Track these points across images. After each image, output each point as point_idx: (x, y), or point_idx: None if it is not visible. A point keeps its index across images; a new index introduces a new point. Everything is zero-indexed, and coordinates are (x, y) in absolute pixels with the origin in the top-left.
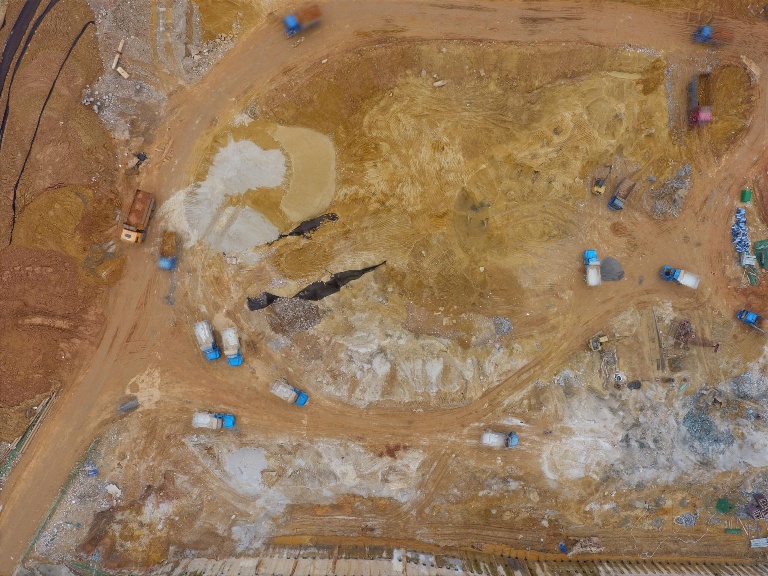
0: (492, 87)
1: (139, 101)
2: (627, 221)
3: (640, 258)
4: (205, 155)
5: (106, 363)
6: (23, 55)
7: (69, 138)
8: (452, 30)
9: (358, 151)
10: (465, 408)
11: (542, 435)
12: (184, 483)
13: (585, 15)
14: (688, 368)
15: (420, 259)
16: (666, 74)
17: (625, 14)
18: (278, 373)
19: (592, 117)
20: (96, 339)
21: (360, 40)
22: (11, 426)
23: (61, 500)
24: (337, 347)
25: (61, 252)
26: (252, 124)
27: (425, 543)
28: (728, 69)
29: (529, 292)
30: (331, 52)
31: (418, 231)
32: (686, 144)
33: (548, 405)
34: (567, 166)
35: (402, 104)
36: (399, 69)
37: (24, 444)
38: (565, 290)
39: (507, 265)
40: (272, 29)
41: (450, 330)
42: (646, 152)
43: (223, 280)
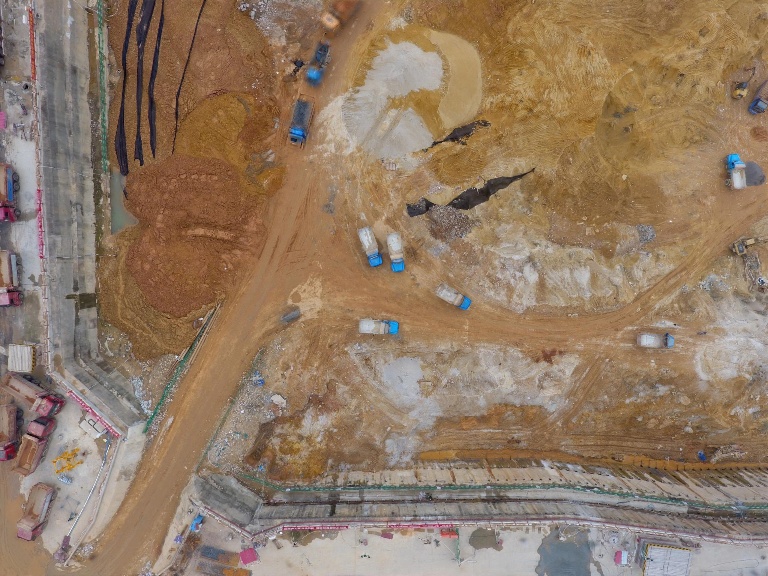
0: None
1: (295, 6)
2: (767, 125)
3: None
4: (362, 60)
5: (268, 273)
6: None
7: (228, 44)
8: None
9: (503, 58)
10: (619, 312)
11: (695, 336)
12: (345, 393)
13: None
14: None
15: (566, 167)
16: None
17: None
18: (439, 279)
19: (733, 20)
20: (257, 250)
21: None
22: (180, 336)
23: (230, 410)
24: (490, 255)
25: (223, 160)
26: (407, 28)
27: (568, 455)
28: None
29: (671, 199)
30: None
31: (567, 137)
32: None
33: (698, 308)
34: (712, 68)
35: (545, 10)
36: None
37: (192, 355)
38: (707, 196)
39: (649, 173)
40: None
41: (593, 240)
42: None
43: (382, 187)
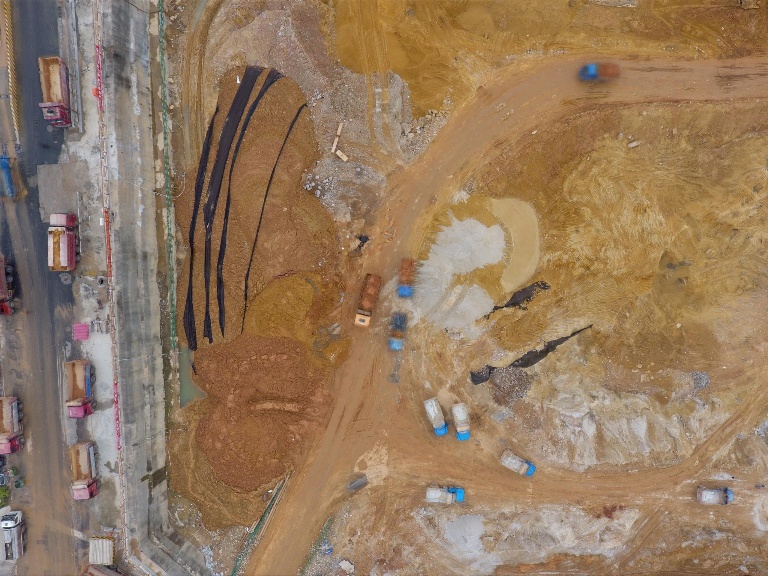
0: (683, 145)
1: (359, 183)
2: None
3: None
4: (426, 234)
5: (335, 443)
6: (241, 142)
7: (296, 225)
8: (651, 93)
9: (560, 217)
10: (677, 466)
11: (753, 489)
12: (410, 554)
13: None
14: None
15: (623, 320)
16: None
17: None
18: (502, 444)
19: None
20: (324, 420)
21: (566, 109)
22: (252, 511)
23: None
24: (550, 413)
25: (292, 338)
26: (469, 200)
27: None
28: None
29: (725, 346)
30: (540, 123)
31: (624, 294)
32: None
33: (755, 458)
34: (766, 222)
35: (600, 167)
36: (598, 133)
37: (263, 528)
38: (760, 342)
39: (702, 320)
40: (482, 103)
41: (648, 386)
42: None
43: (446, 356)
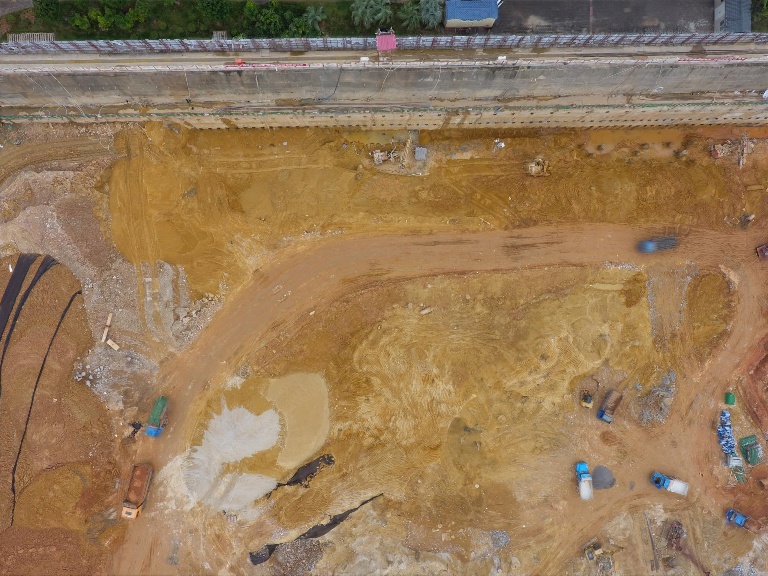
0: (478, 309)
1: (131, 372)
2: (616, 430)
3: (630, 465)
4: (200, 420)
5: None
6: (12, 332)
7: (64, 417)
8: (436, 265)
9: (350, 387)
10: None
11: None
12: None
13: (566, 238)
14: (681, 564)
15: (416, 486)
16: (647, 287)
17: (605, 233)
18: None
19: (577, 334)
20: None
21: (346, 287)
22: None
23: None
24: None
25: (63, 528)
26: (244, 384)
27: None
28: (707, 277)
29: (524, 505)
30: (318, 303)
31: (413, 464)
32: (670, 350)
33: None
34: (555, 388)
35: (391, 336)
36: (386, 305)
37: None
38: (559, 501)
39: (501, 480)
40: (258, 286)
41: (449, 545)
42: (631, 361)
43: (225, 537)
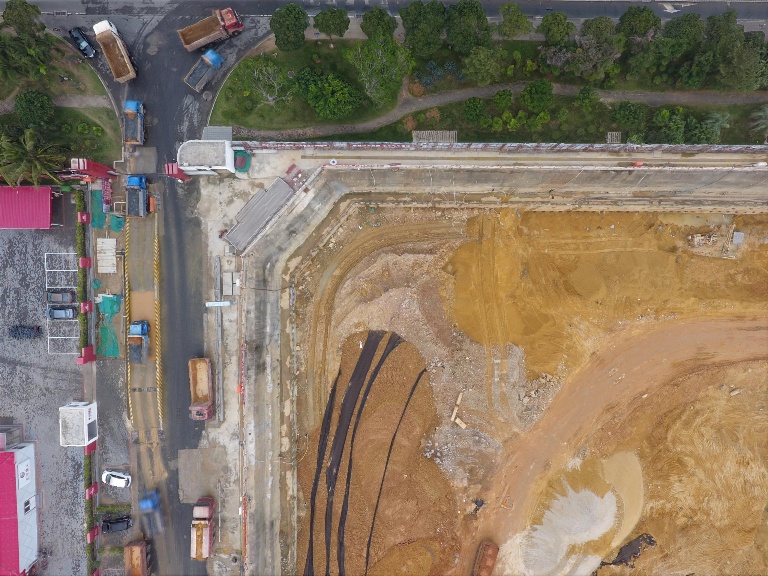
0: None
1: (477, 451)
2: None
3: None
4: (540, 499)
5: None
6: (363, 408)
7: (416, 494)
8: (756, 350)
9: (664, 466)
10: None
11: None
12: None
13: None
14: None
15: (723, 566)
16: None
17: None
18: None
19: None
20: None
21: (675, 371)
22: None
23: None
24: None
25: None
26: (582, 466)
27: None
28: None
29: None
30: (650, 386)
31: (727, 546)
32: None
33: None
34: None
35: (703, 417)
36: (703, 387)
37: None
38: None
39: None
40: (595, 368)
41: None
42: None
43: None
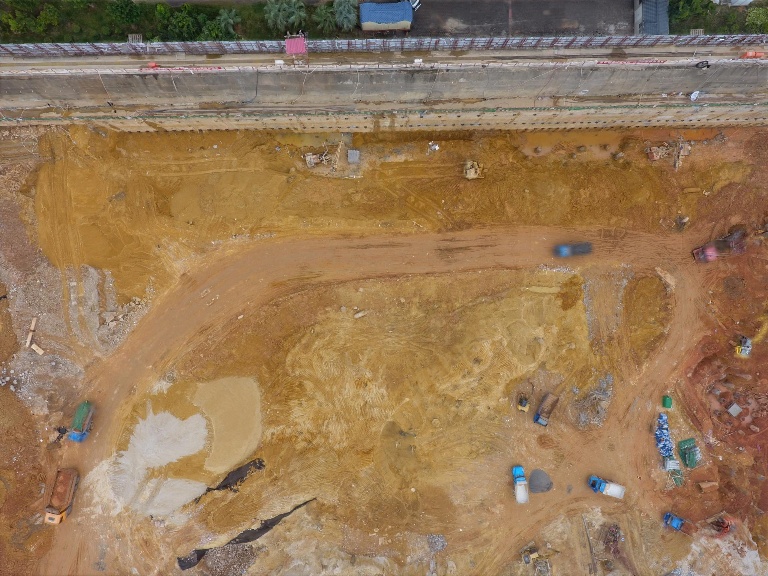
0: (413, 312)
1: (55, 377)
2: (553, 433)
3: (567, 468)
4: (125, 425)
5: None
6: None
7: None
8: (368, 269)
9: (282, 391)
10: None
11: None
12: None
13: (500, 241)
14: (620, 568)
15: (351, 490)
16: (583, 289)
17: (539, 236)
18: None
19: (513, 337)
20: None
21: (275, 291)
22: None
23: None
24: None
25: None
26: (171, 389)
27: None
28: (644, 280)
29: (461, 509)
30: (247, 307)
31: (346, 468)
32: (607, 353)
33: None
34: (489, 392)
35: (324, 340)
36: (318, 309)
37: None
38: (496, 504)
39: (438, 483)
40: (186, 290)
41: (386, 549)
42: (568, 364)
43: (152, 542)
